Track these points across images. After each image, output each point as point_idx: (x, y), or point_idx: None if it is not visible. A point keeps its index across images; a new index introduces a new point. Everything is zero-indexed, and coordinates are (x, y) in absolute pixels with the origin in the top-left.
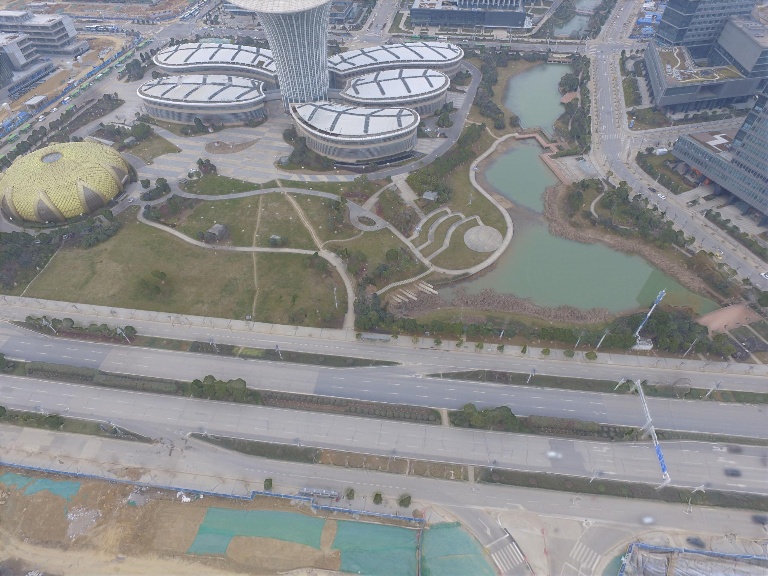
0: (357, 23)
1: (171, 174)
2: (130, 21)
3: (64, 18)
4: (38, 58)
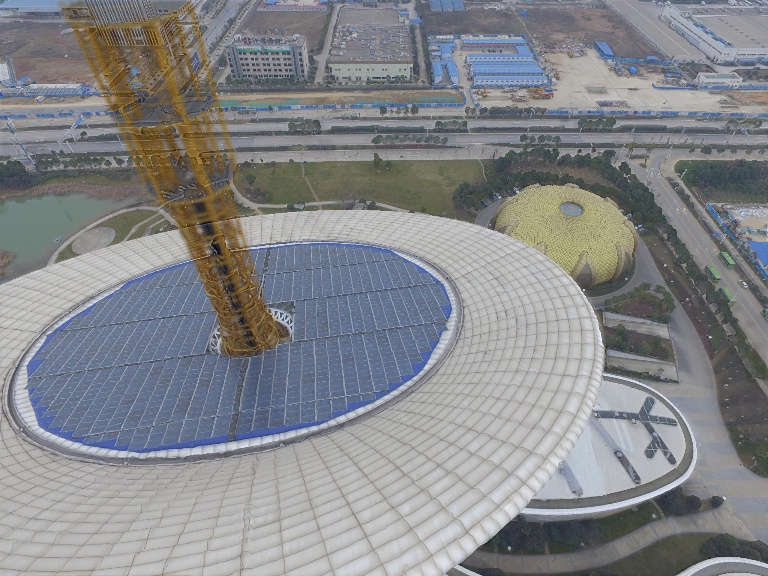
0: None
1: None
2: None
3: None
4: None
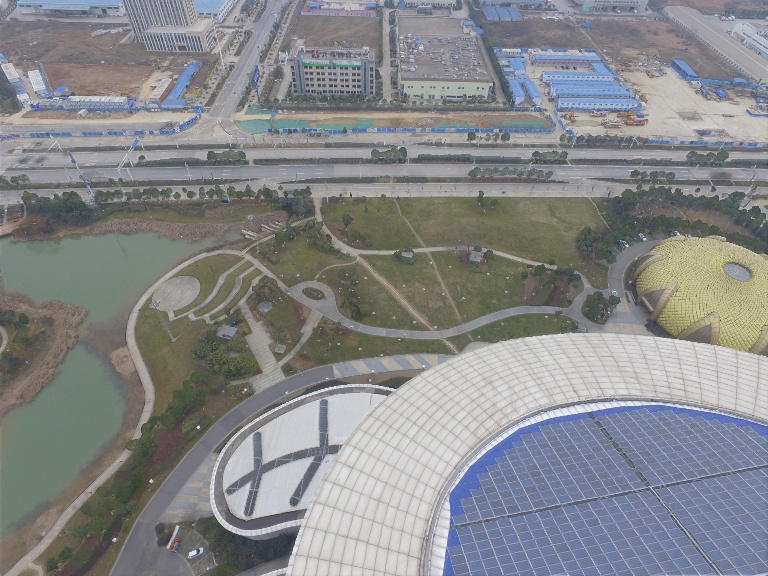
0: None
1: None
2: None
3: None
4: None
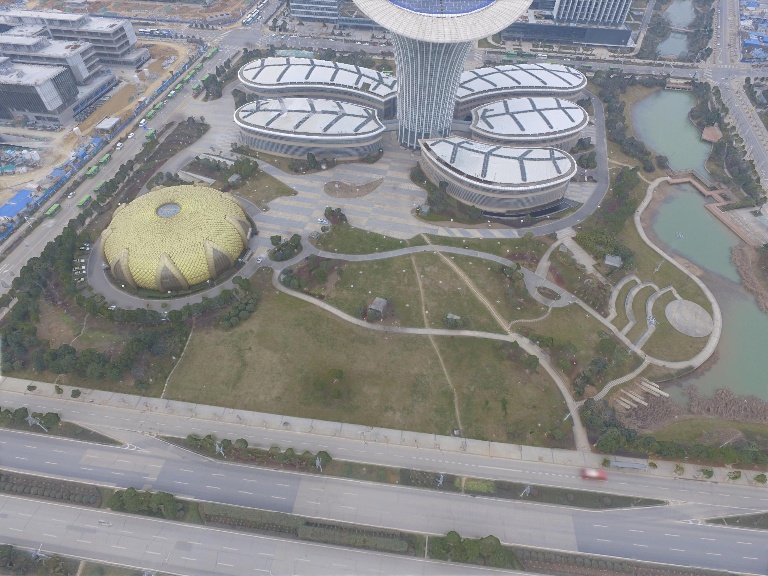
0: None
1: (295, 224)
2: (186, 24)
3: (125, 23)
4: (99, 70)
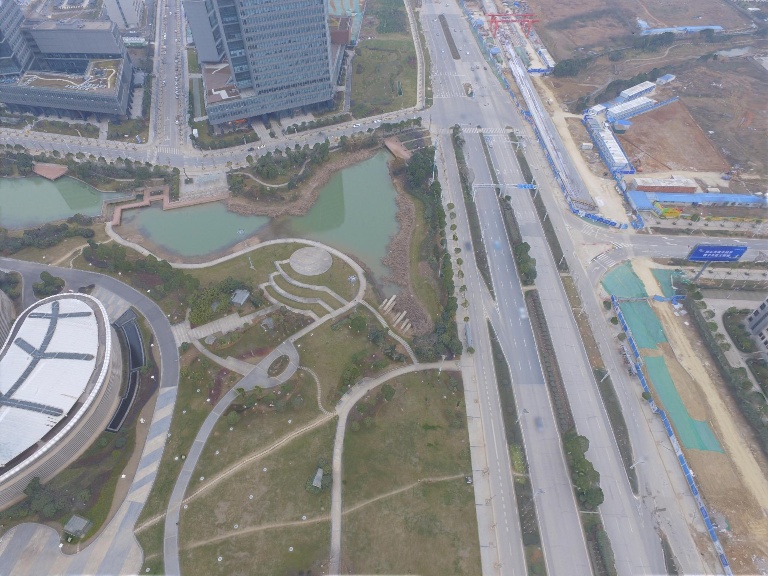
0: None
1: None
2: None
3: None
4: None
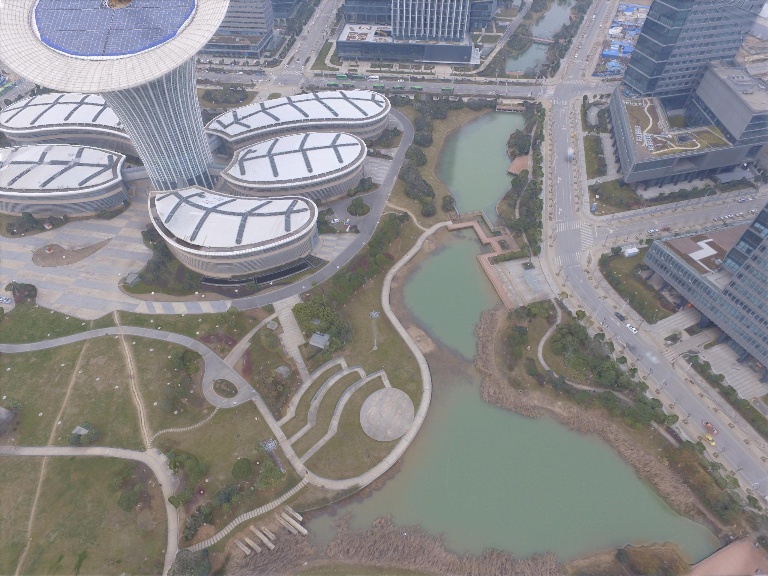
0: (274, 57)
1: None
2: None
3: None
4: None
